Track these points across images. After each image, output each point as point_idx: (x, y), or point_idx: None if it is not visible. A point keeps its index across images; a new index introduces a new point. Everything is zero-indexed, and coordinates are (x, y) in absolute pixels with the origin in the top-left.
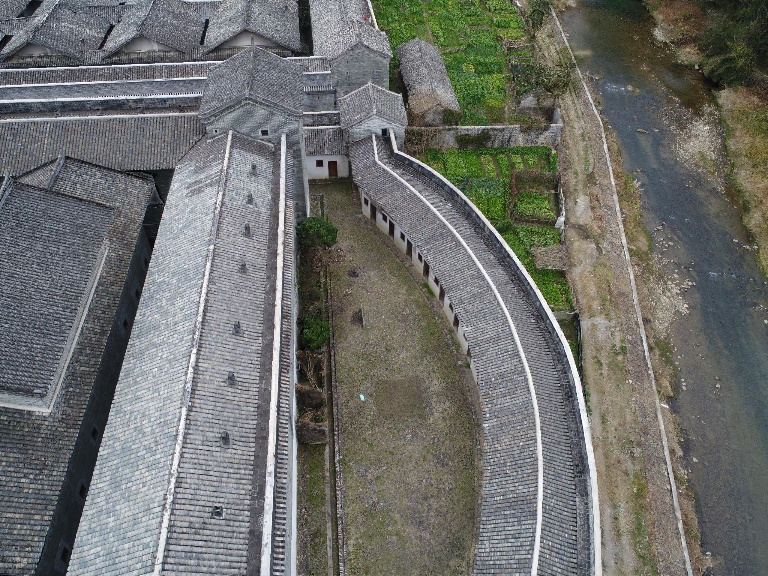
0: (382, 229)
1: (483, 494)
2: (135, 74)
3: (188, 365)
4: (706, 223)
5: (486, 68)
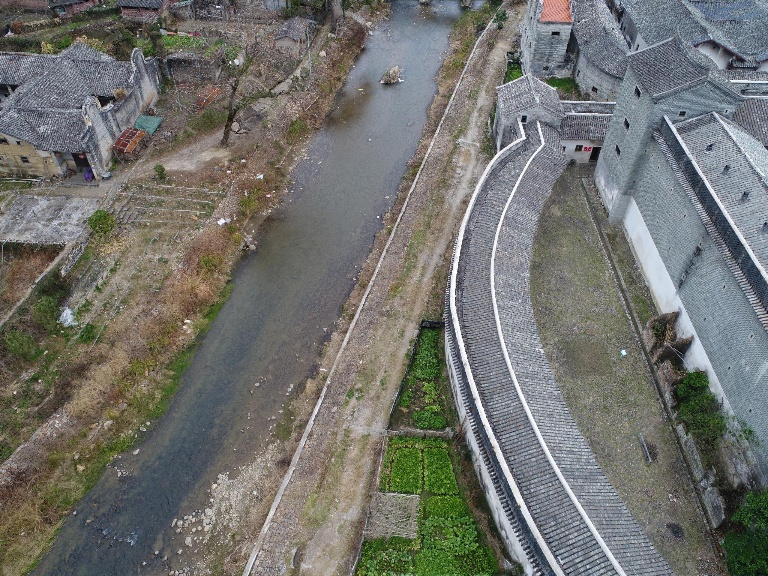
0: None
1: None
2: None
3: None
4: None
5: None
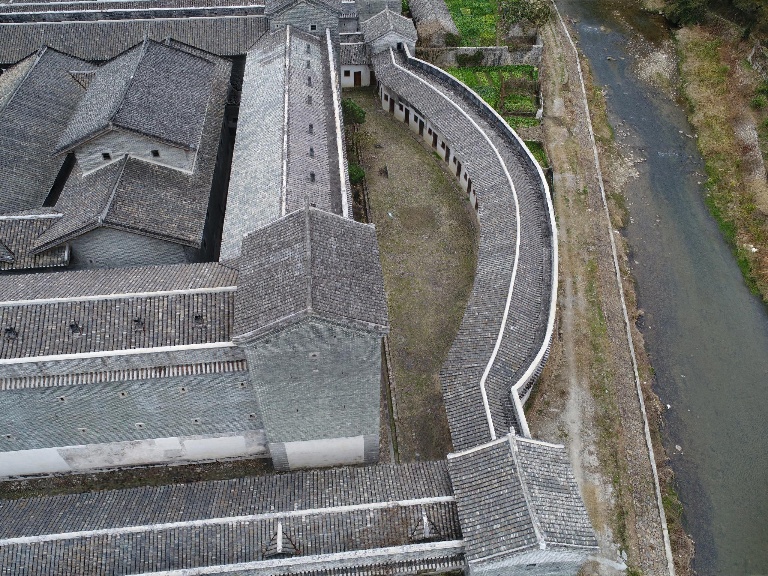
0: (399, 118)
1: (479, 248)
2: (196, 5)
3: (282, 143)
4: (658, 121)
5: (480, 11)
